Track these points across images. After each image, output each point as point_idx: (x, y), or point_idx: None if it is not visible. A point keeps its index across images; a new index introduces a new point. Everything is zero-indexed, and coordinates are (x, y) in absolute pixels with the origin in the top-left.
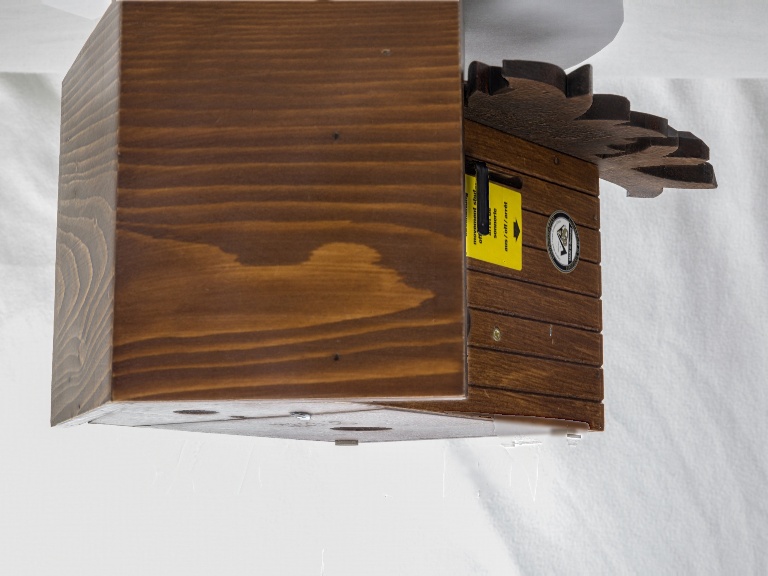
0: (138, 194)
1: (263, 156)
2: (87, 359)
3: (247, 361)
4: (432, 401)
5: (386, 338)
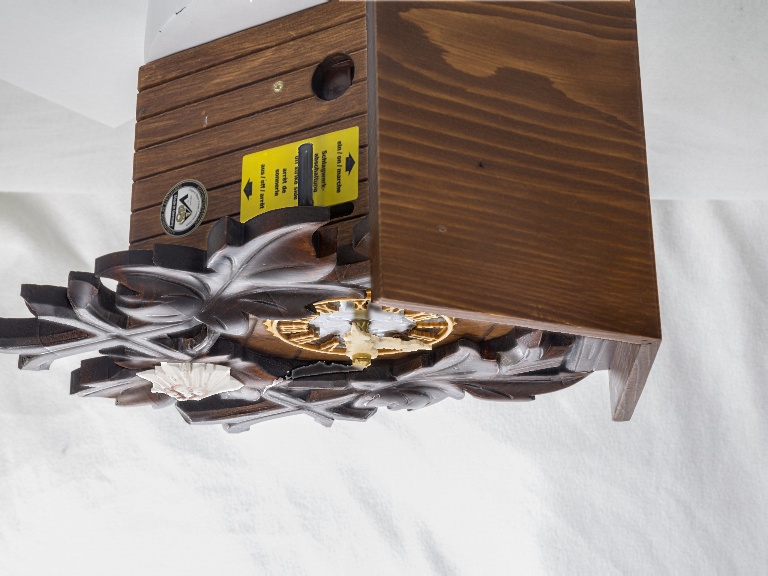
0: (631, 156)
1: (538, 162)
2: None
3: (540, 3)
4: (360, 1)
5: None
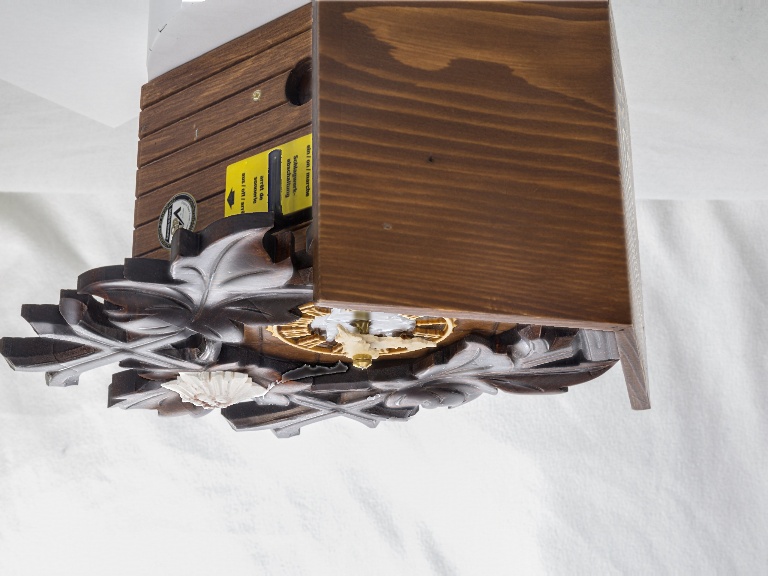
0: (600, 138)
1: (495, 153)
2: None
3: None
4: None
5: None
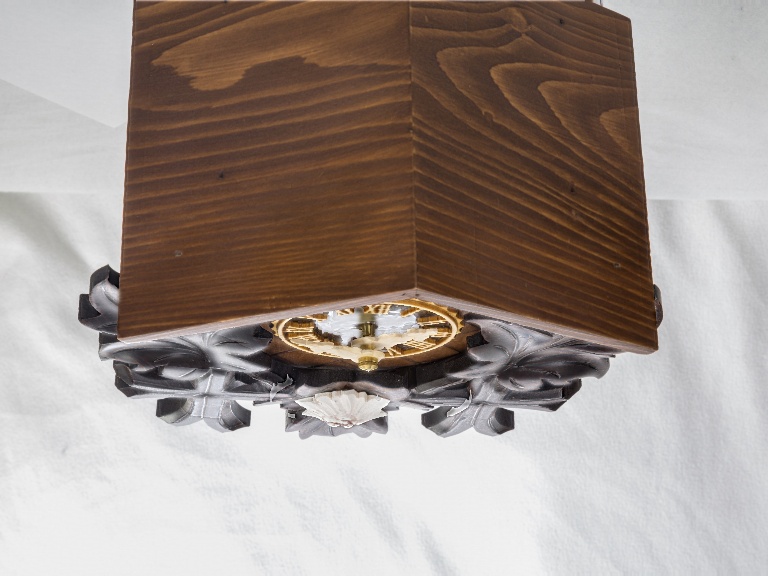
0: (392, 98)
1: (282, 149)
2: (496, 3)
3: None
4: None
5: (188, 23)
